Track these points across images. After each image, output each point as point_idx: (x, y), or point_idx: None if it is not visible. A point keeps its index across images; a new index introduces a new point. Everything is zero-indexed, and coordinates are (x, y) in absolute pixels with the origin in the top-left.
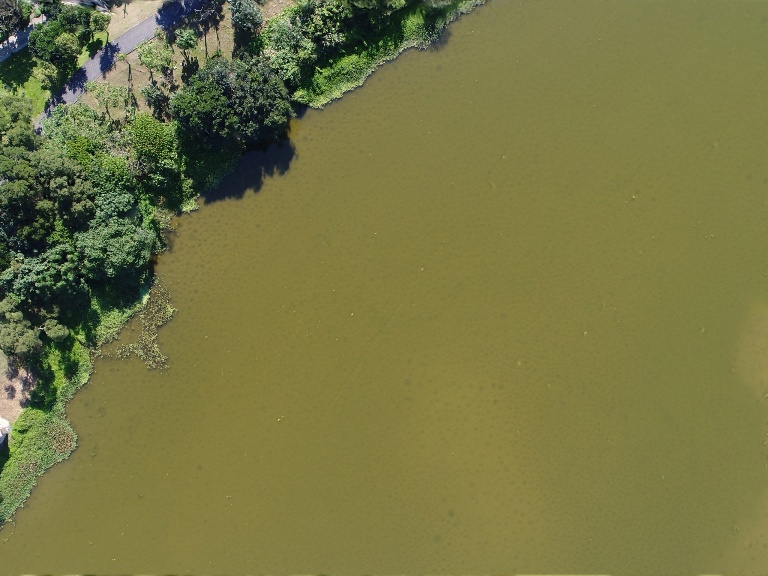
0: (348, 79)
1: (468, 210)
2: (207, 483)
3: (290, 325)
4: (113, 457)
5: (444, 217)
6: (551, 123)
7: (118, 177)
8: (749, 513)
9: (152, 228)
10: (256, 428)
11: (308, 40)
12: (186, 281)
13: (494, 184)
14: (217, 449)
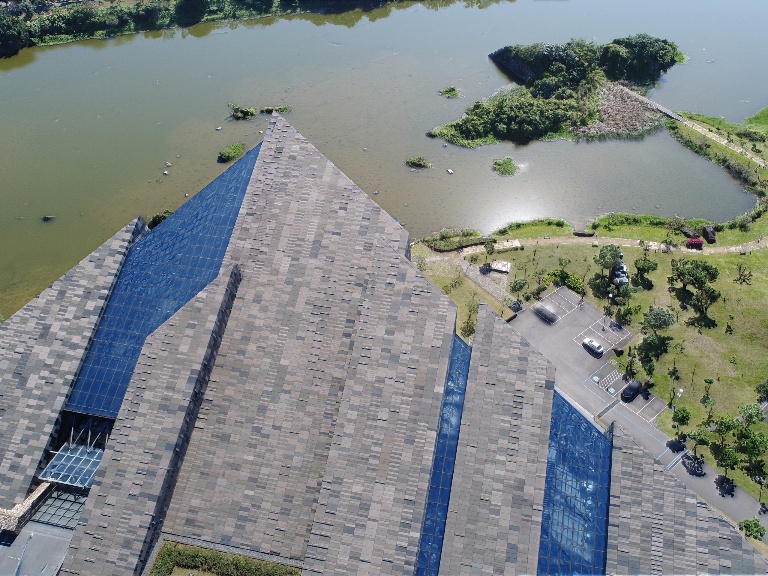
0: (60, 41)
1: None
2: None
3: None
4: None
5: None
6: (138, 62)
7: None
8: (132, 186)
9: None
10: None
11: None
12: None
13: None
14: None
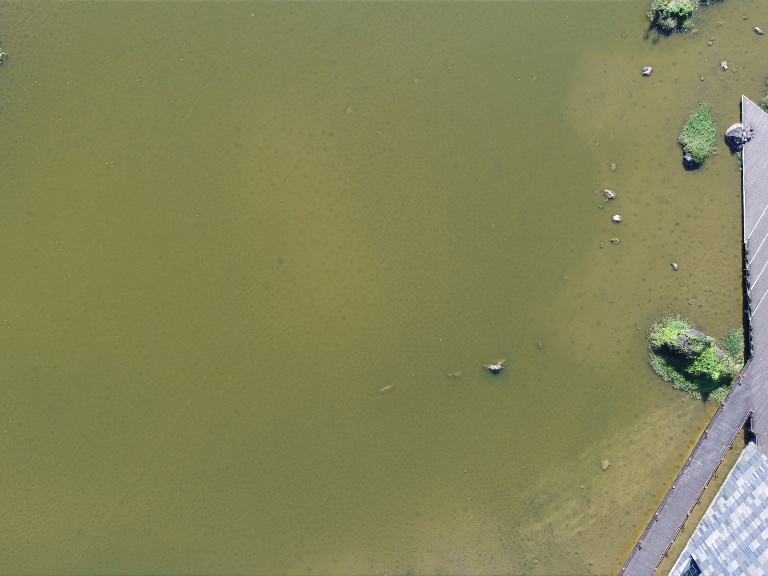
0: None
1: None
2: (37, 228)
3: (120, 71)
4: None
5: None
6: None
7: None
8: (579, 262)
9: None
10: (86, 174)
11: None
12: (16, 25)
13: None
14: (47, 195)
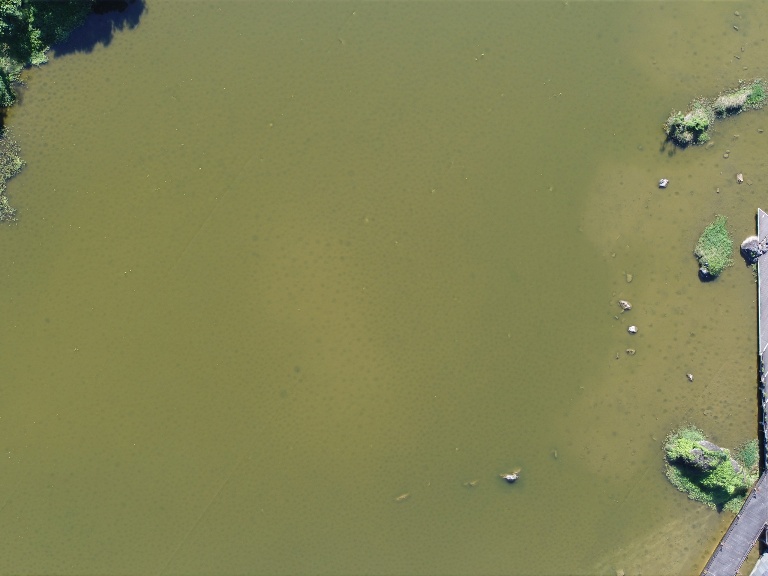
0: None
1: (318, 66)
2: (55, 336)
3: (139, 179)
4: None
5: (293, 73)
6: None
7: None
8: (595, 373)
9: (1, 79)
10: (104, 282)
11: None
12: (35, 134)
13: (344, 40)
14: (65, 302)
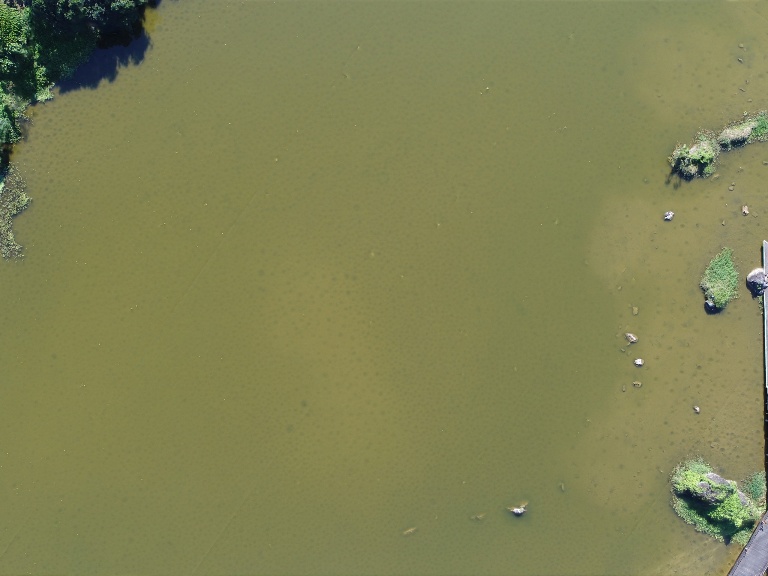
0: None
1: (322, 101)
2: (61, 372)
3: (144, 215)
4: None
5: (298, 108)
6: (406, 14)
7: None
8: (601, 405)
9: (6, 116)
10: (110, 317)
11: None
12: (41, 170)
13: (348, 75)
14: (72, 338)
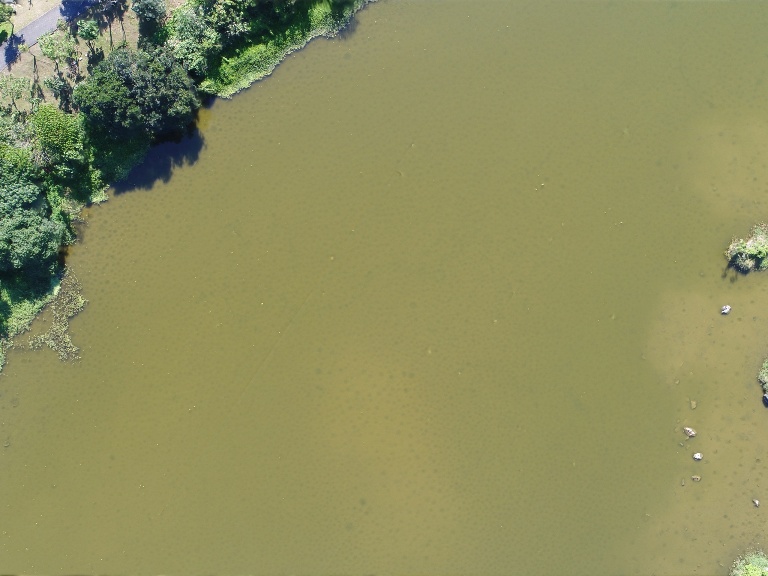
0: (256, 69)
1: (377, 199)
2: (120, 473)
3: (201, 315)
4: (26, 447)
5: (353, 206)
6: (460, 111)
7: (21, 168)
8: (660, 500)
9: (62, 219)
10: (168, 418)
11: (212, 30)
12: (97, 272)
13: (403, 173)
14: (129, 439)
